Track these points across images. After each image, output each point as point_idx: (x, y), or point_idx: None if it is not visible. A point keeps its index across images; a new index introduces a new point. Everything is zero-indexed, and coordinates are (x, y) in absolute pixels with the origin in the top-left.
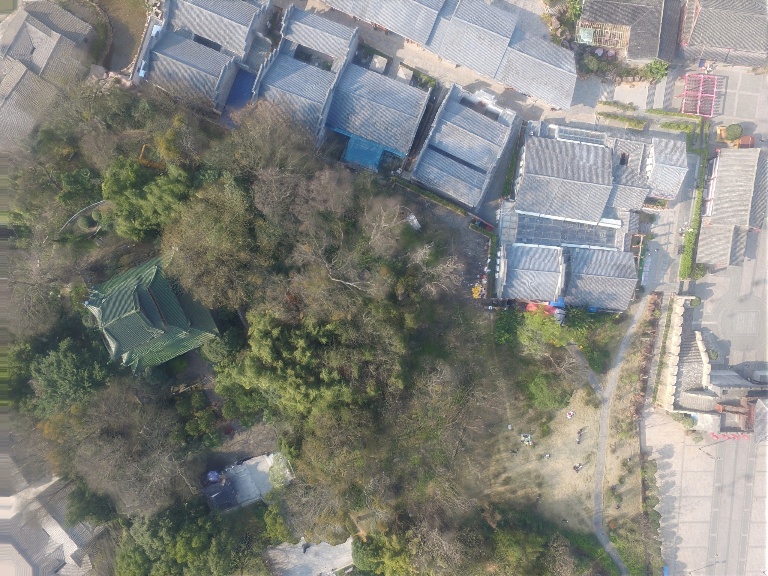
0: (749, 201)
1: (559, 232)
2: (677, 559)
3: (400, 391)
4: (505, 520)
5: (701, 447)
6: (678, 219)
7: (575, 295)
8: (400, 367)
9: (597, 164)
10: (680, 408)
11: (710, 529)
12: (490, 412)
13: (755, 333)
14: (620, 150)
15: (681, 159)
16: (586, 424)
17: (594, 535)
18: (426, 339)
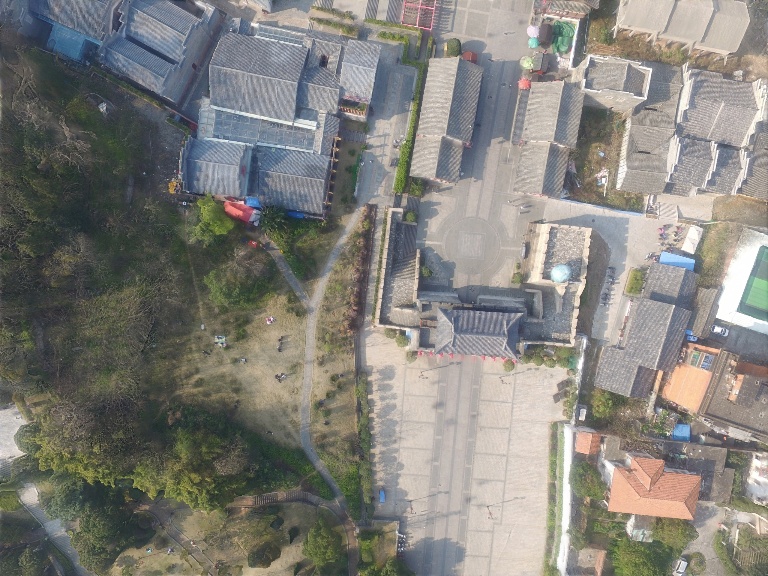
0: (448, 110)
1: (256, 131)
2: (398, 486)
3: (32, 259)
4: (195, 422)
5: (423, 371)
6: (394, 131)
7: (267, 194)
8: (30, 234)
9: (289, 62)
10: (389, 324)
11: (433, 457)
12: (181, 309)
13: (481, 256)
14: (319, 51)
15: (372, 61)
16: (289, 332)
17: (301, 450)
18: (86, 218)
